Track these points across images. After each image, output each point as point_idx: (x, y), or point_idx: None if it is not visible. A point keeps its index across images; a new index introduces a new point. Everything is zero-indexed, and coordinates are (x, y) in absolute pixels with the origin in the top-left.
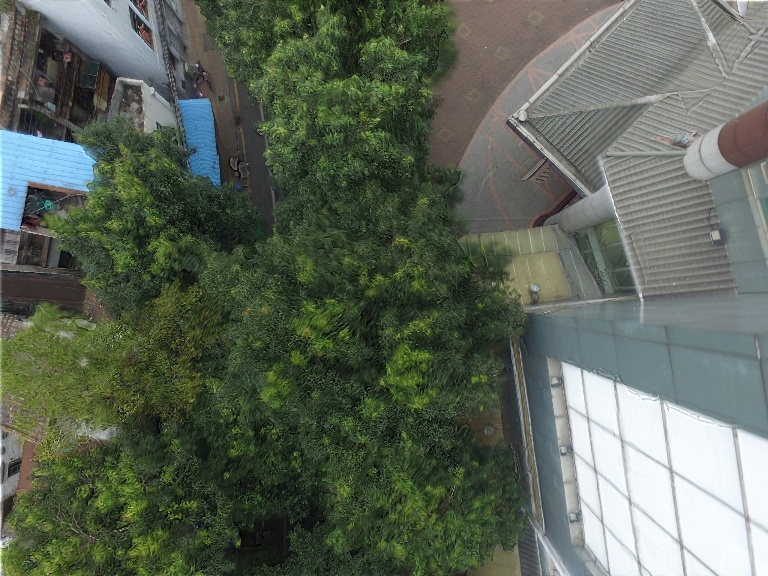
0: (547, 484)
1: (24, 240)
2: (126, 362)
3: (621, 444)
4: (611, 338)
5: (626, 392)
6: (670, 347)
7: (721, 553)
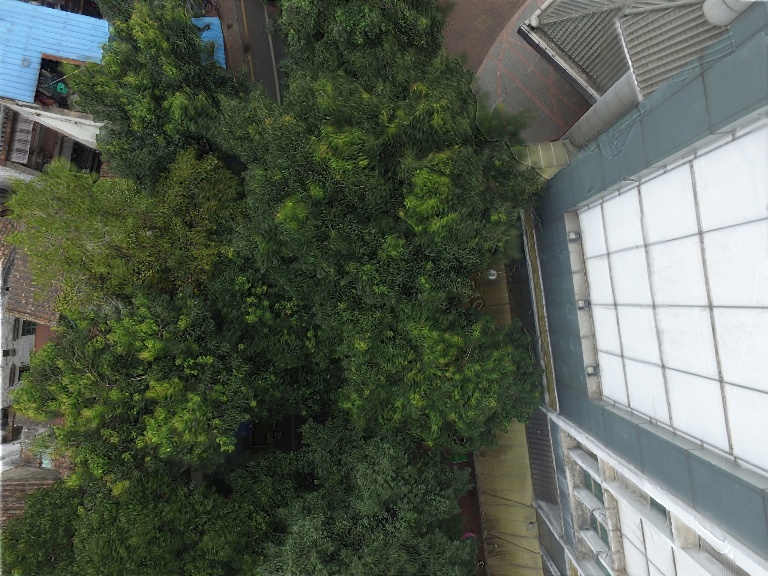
0: (562, 356)
1: (34, 145)
2: (141, 223)
3: (645, 249)
4: (637, 124)
5: (651, 189)
6: (704, 73)
7: (755, 276)
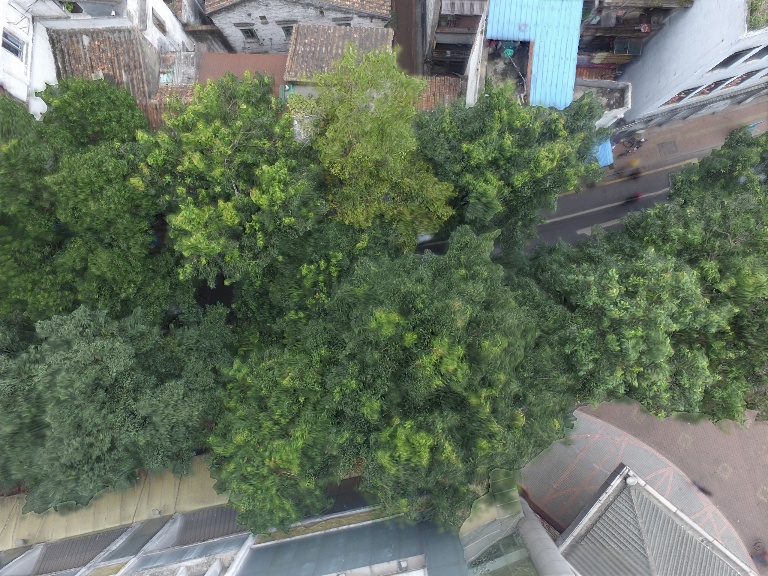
0: (300, 552)
1: None
2: (379, 163)
3: None
4: None
5: None
6: None
7: None
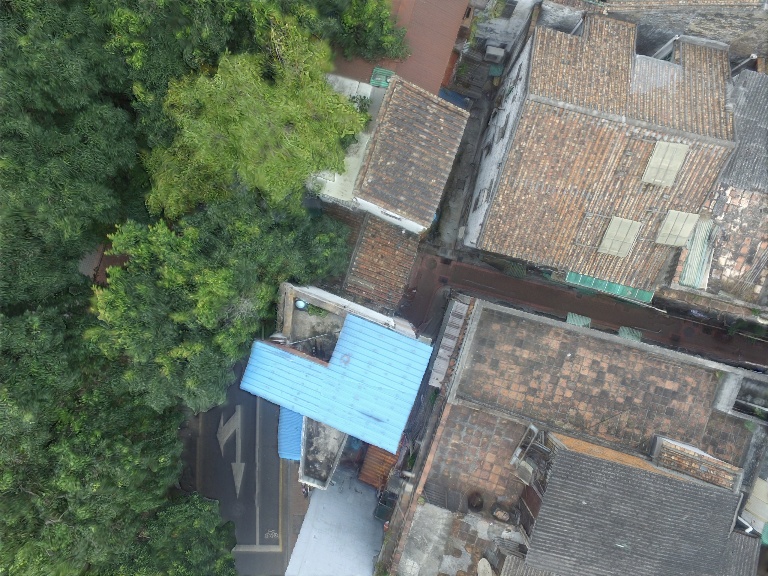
0: None
1: None
2: None
3: None
4: None
5: None
6: None
7: None
